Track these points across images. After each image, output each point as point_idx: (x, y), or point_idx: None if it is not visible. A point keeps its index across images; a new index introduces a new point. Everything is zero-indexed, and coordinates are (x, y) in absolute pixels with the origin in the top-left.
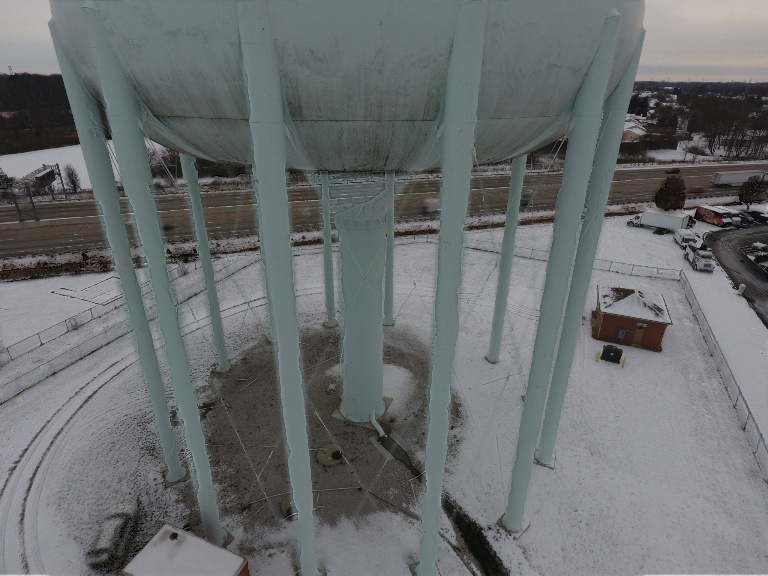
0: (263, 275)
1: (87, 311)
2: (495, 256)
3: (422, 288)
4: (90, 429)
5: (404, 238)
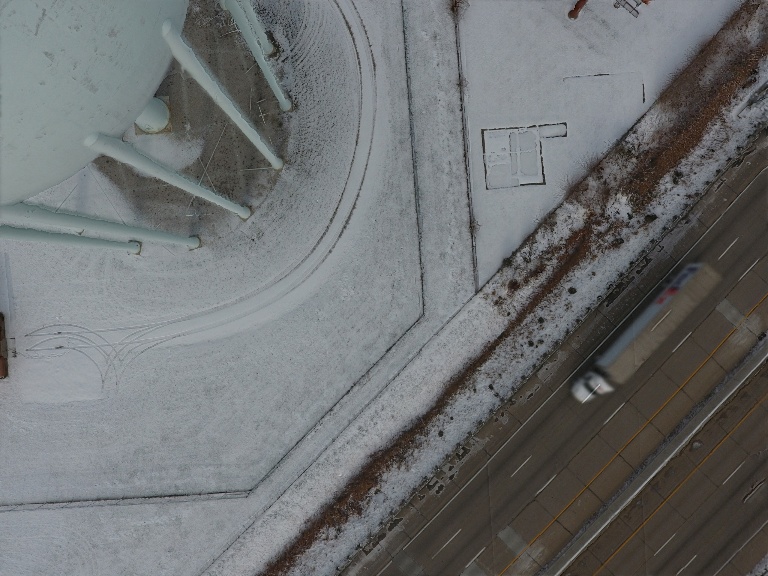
0: (384, 273)
1: (486, 113)
2: (144, 483)
3: (195, 337)
4: (315, 6)
5: (288, 489)
